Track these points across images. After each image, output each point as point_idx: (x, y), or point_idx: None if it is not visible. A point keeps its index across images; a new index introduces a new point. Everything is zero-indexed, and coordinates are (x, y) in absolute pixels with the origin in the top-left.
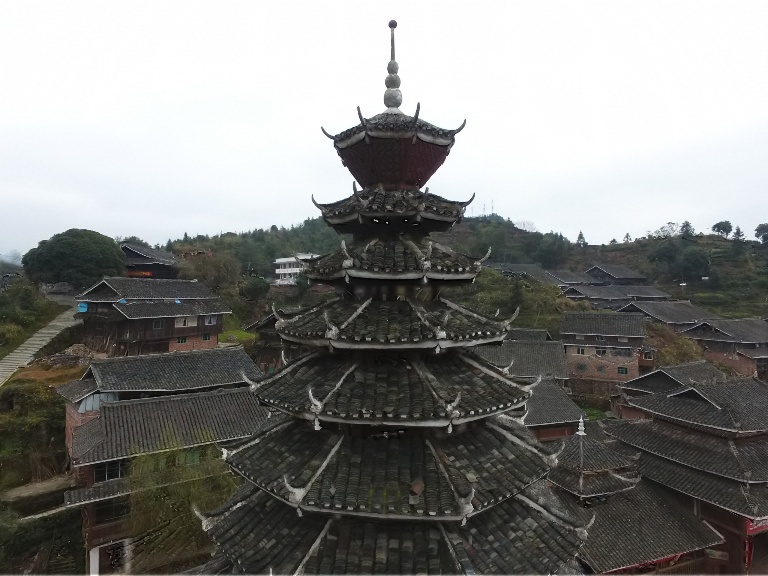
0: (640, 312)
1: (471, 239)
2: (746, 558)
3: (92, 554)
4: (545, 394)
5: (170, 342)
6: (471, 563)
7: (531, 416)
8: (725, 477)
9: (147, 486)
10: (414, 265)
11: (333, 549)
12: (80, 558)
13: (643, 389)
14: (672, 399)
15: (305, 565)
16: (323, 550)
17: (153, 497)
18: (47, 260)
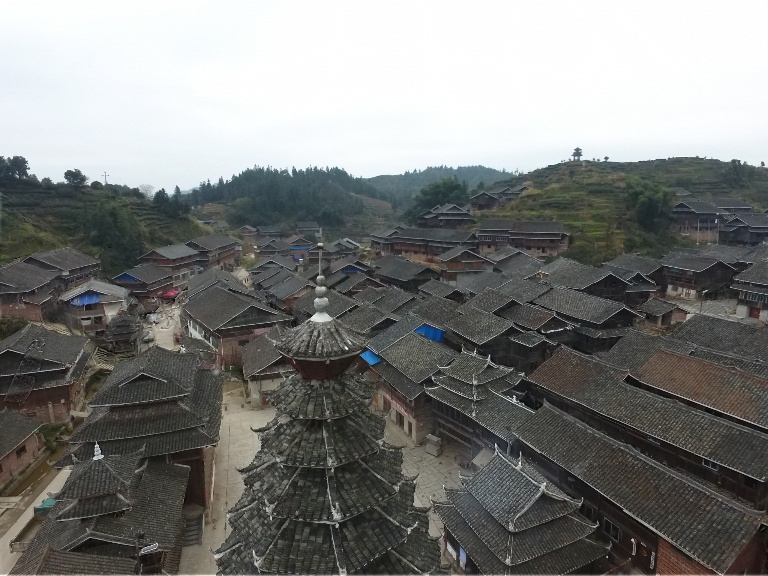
0: None
1: None
2: (204, 470)
3: None
4: None
5: None
6: None
7: None
8: None
9: None
10: (384, 423)
11: None
12: None
13: None
14: (125, 387)
15: None
16: None
17: None
18: None
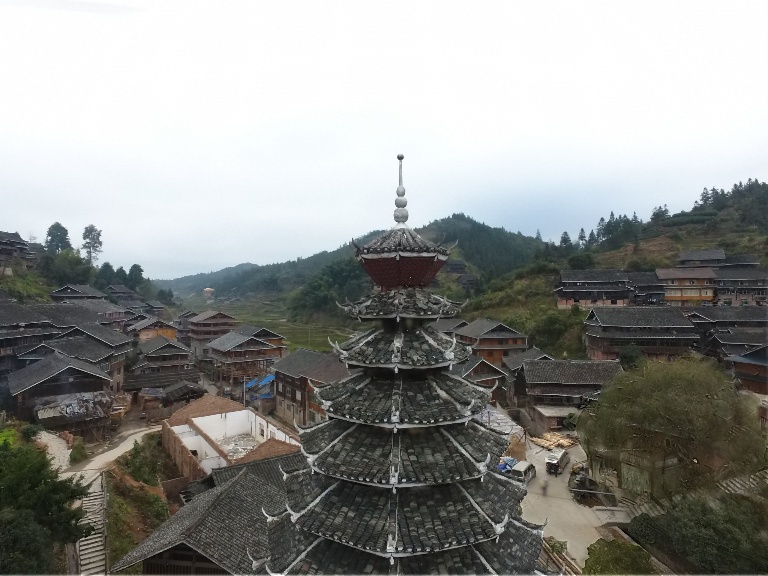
0: None
1: None
2: None
3: None
4: None
5: None
6: None
7: None
8: None
9: None
10: None
11: None
12: None
13: None
14: None
15: None
16: None
17: None
18: None
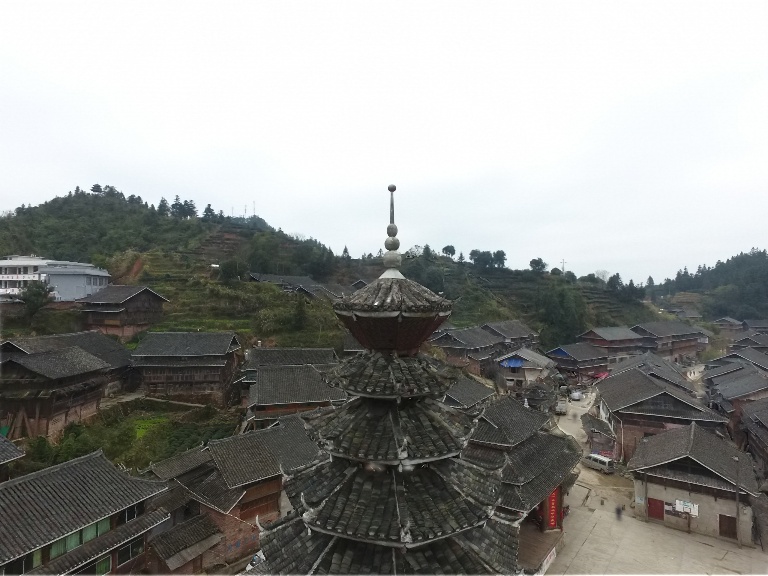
0: None
1: (251, 253)
2: None
3: None
4: None
5: None
6: None
7: None
8: (506, 483)
9: None
10: (455, 445)
11: None
12: None
13: None
14: None
15: None
16: None
17: None
18: None
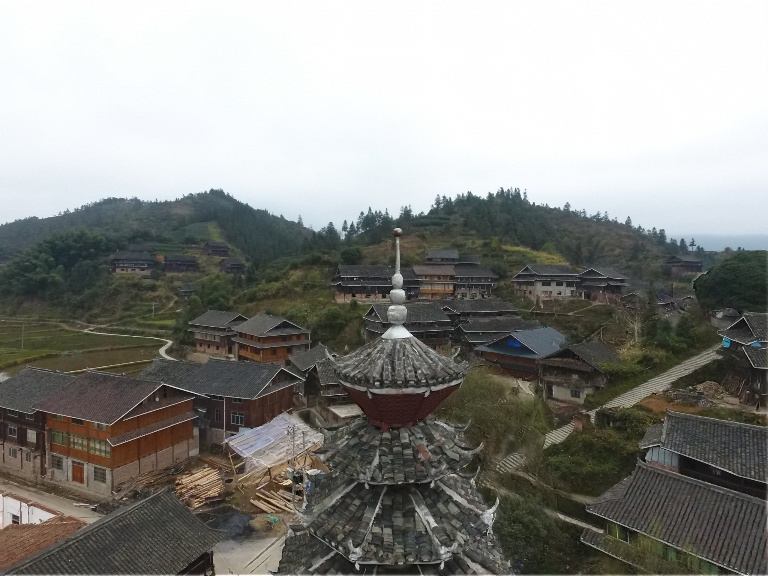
0: None
1: None
2: None
3: None
4: None
5: None
6: None
7: None
8: None
9: (648, 568)
10: None
11: None
12: None
13: None
14: None
15: None
16: None
17: None
18: (711, 286)
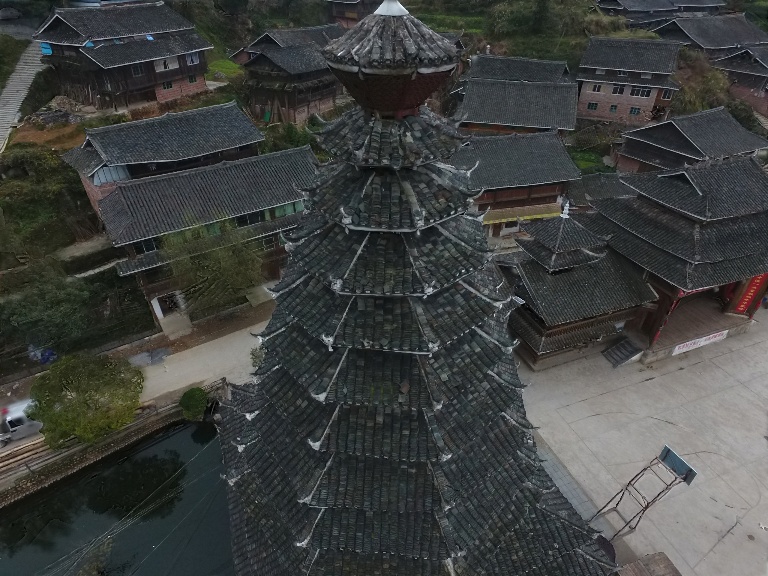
0: (680, 32)
1: None
2: (669, 312)
3: (153, 302)
4: (545, 151)
5: (156, 89)
6: (438, 426)
7: (526, 176)
8: (678, 256)
9: (182, 256)
10: (408, 222)
11: (347, 415)
12: (143, 302)
13: (647, 140)
14: (661, 179)
15: (330, 427)
16: (341, 416)
17: (189, 263)
18: None
